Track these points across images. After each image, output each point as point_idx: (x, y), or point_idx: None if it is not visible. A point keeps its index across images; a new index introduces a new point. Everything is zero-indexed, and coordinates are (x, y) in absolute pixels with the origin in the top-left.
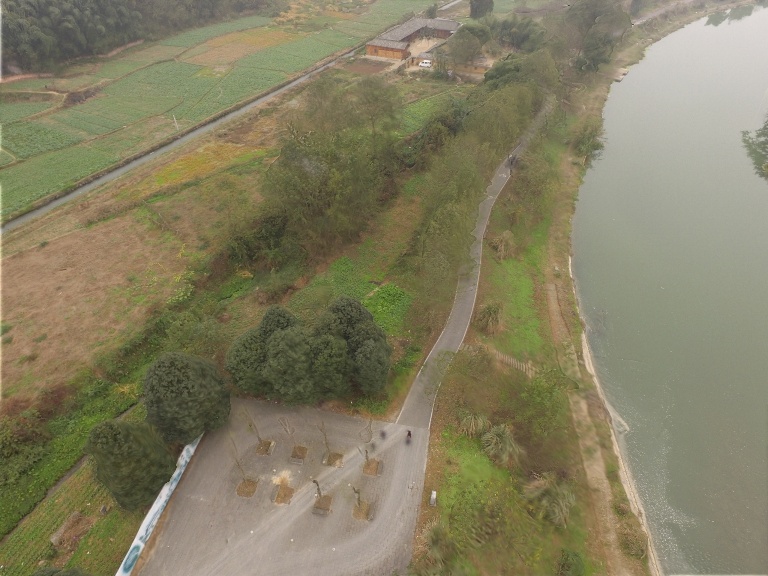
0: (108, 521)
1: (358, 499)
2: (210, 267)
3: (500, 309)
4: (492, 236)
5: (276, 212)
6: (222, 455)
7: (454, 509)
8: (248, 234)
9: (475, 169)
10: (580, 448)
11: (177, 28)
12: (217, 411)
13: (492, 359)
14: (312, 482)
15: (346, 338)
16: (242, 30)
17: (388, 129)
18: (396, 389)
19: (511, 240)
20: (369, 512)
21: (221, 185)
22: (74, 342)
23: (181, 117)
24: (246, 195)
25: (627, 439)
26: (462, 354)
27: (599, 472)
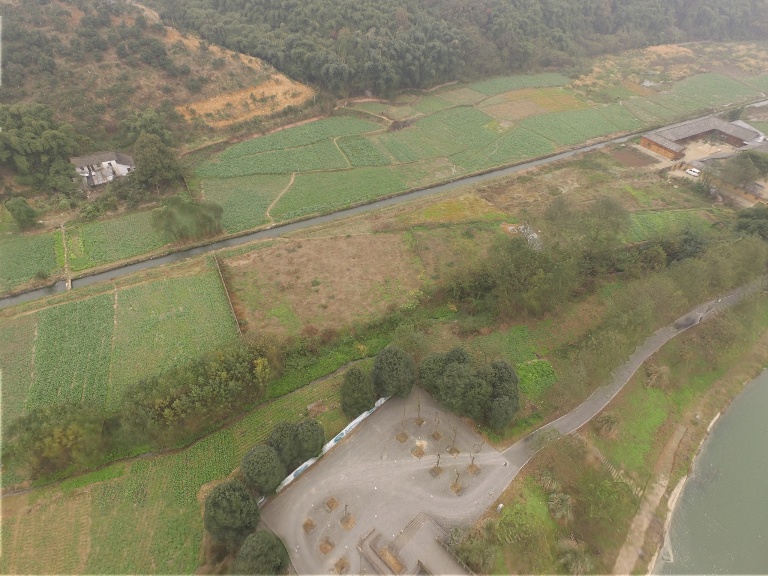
0: (333, 413)
1: (457, 479)
2: (433, 294)
3: (617, 423)
4: (653, 363)
5: (492, 272)
6: (396, 413)
7: (507, 517)
8: (466, 283)
9: (650, 313)
10: (622, 547)
11: (487, 74)
12: (404, 388)
13: (587, 452)
14: (436, 456)
15: (494, 387)
16: (539, 87)
17: (609, 239)
18: (512, 434)
19: (666, 375)
20: (459, 491)
21: (464, 234)
22: (346, 307)
23: (459, 164)
24: (477, 249)
25: (666, 566)
26: (564, 437)
27: (626, 569)
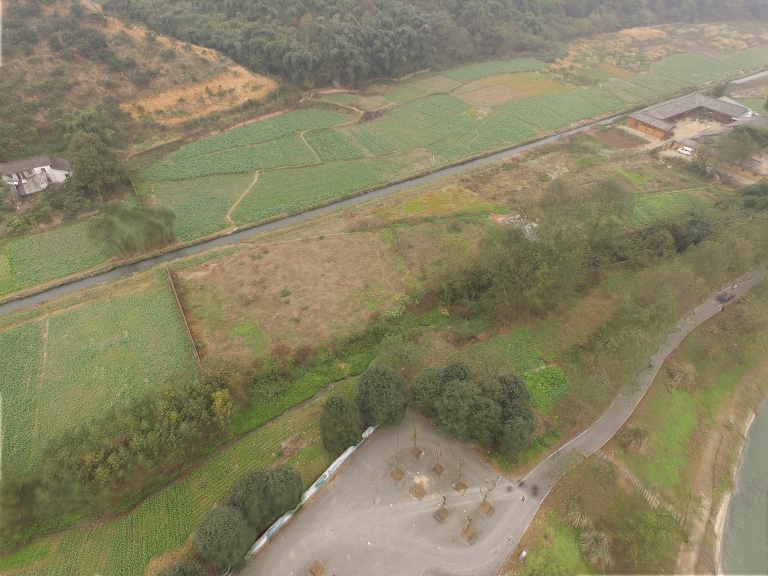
0: (312, 449)
1: (468, 525)
2: (422, 297)
3: (647, 437)
4: (675, 362)
5: (485, 269)
6: (388, 443)
7: (534, 573)
8: (458, 283)
9: (675, 307)
10: None
11: (460, 61)
12: (397, 414)
13: (619, 477)
14: (440, 495)
15: (503, 406)
16: (514, 72)
17: (612, 225)
18: (527, 459)
19: (692, 375)
20: (472, 538)
21: (450, 228)
22: (323, 319)
23: (438, 153)
24: (466, 244)
25: None
26: (592, 462)
27: None
